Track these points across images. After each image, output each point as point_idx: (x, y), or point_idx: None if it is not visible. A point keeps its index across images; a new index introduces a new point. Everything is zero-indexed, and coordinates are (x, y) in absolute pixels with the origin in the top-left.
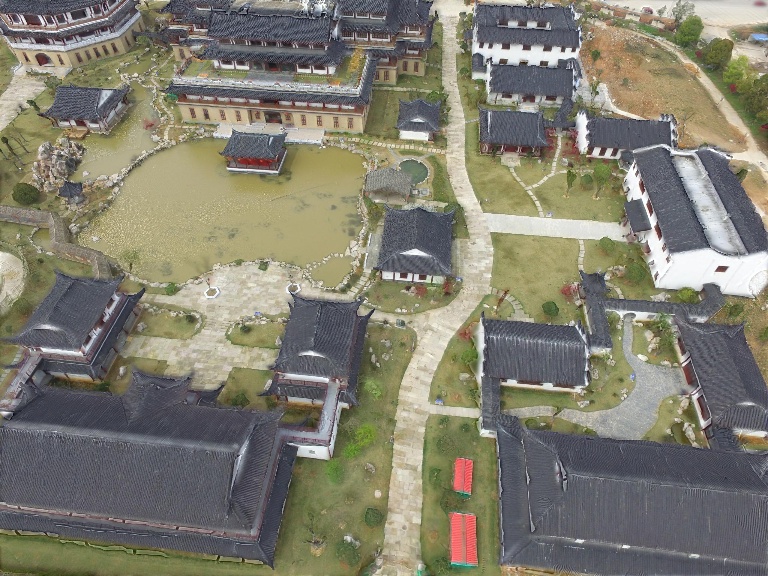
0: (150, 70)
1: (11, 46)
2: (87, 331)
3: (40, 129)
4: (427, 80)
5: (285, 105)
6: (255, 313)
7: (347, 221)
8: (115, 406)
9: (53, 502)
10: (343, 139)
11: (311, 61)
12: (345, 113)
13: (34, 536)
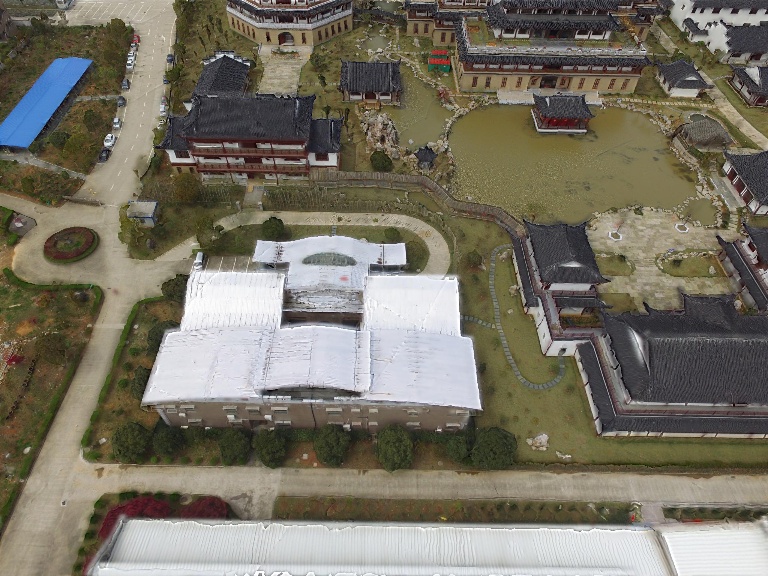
0: (391, 45)
1: (255, 26)
2: (597, 266)
3: (331, 104)
4: (650, 45)
5: (568, 70)
6: (669, 250)
7: (677, 170)
8: (692, 321)
9: (716, 397)
10: (619, 99)
11: (596, 27)
12: (625, 75)
13: (649, 438)
